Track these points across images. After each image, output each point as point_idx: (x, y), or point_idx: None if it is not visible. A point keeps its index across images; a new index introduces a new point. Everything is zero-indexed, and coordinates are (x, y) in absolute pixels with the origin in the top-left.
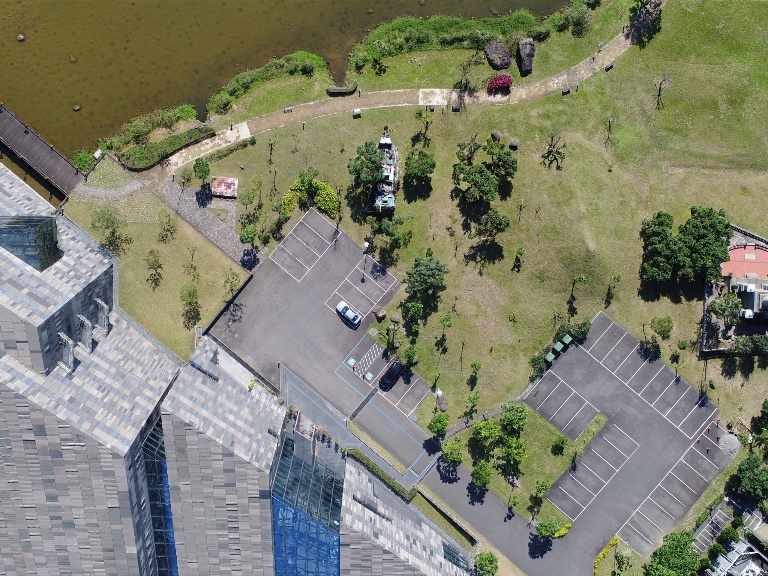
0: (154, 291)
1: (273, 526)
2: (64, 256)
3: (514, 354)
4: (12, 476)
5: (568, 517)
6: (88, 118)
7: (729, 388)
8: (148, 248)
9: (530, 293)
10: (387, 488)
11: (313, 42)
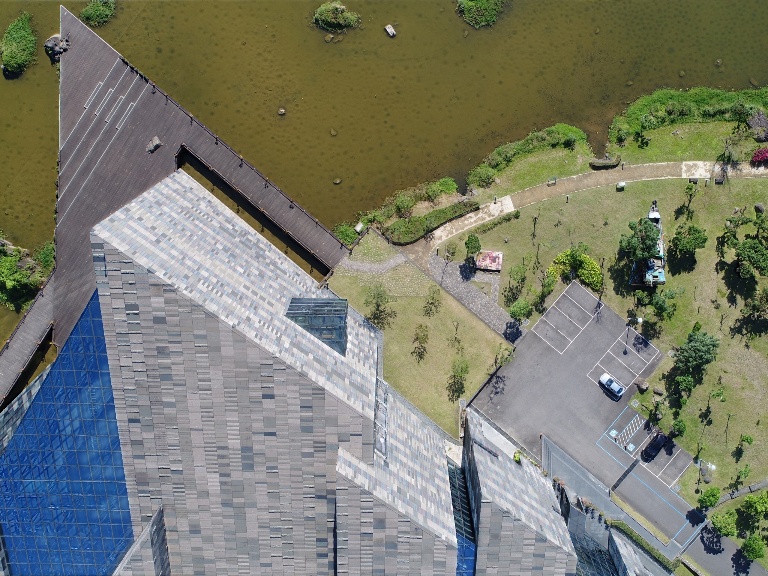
0: (418, 364)
1: None
2: (348, 335)
3: None
4: (343, 566)
5: None
6: (348, 191)
7: None
8: (412, 321)
9: None
10: (650, 558)
11: (572, 114)
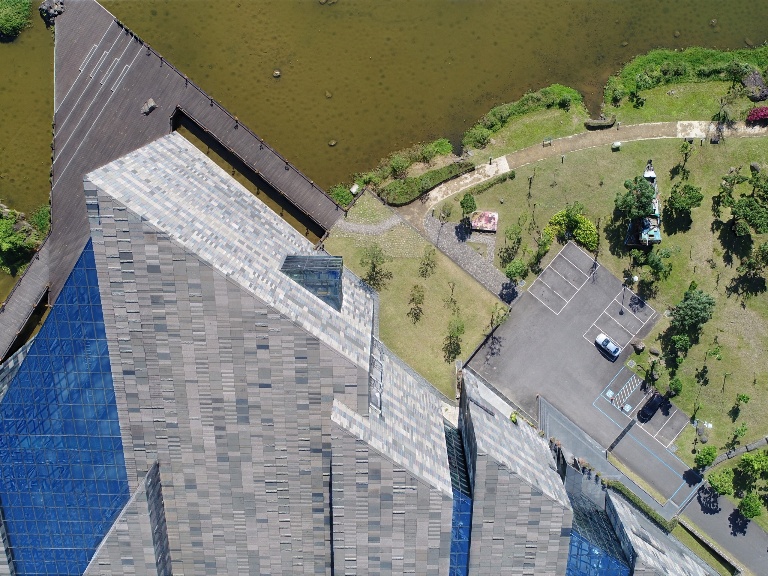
0: (414, 325)
1: None
2: (343, 294)
3: None
4: (338, 518)
5: None
6: (344, 153)
7: None
8: (408, 282)
9: None
10: (647, 519)
11: (568, 75)
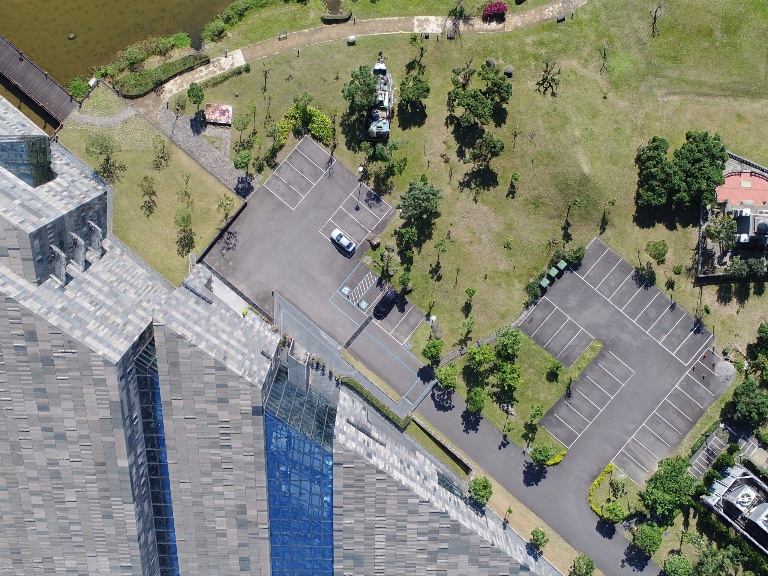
0: (148, 218)
1: (266, 445)
2: (58, 178)
3: (509, 281)
4: (3, 385)
5: (563, 444)
6: (83, 46)
7: (725, 315)
8: (142, 175)
9: (525, 219)
10: (381, 417)
11: None
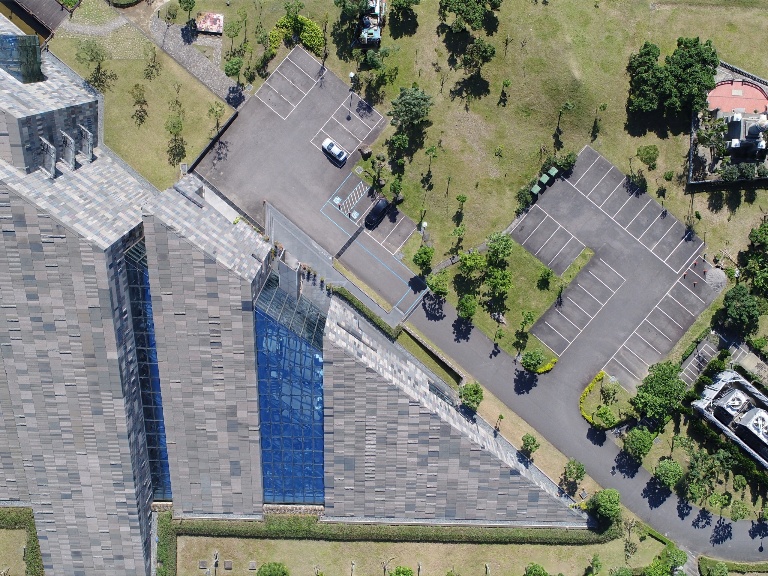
0: (139, 128)
1: (256, 344)
2: (48, 80)
3: (500, 189)
4: None
5: (554, 352)
6: None
7: (716, 222)
8: (133, 84)
9: (516, 127)
10: (372, 327)
11: None
